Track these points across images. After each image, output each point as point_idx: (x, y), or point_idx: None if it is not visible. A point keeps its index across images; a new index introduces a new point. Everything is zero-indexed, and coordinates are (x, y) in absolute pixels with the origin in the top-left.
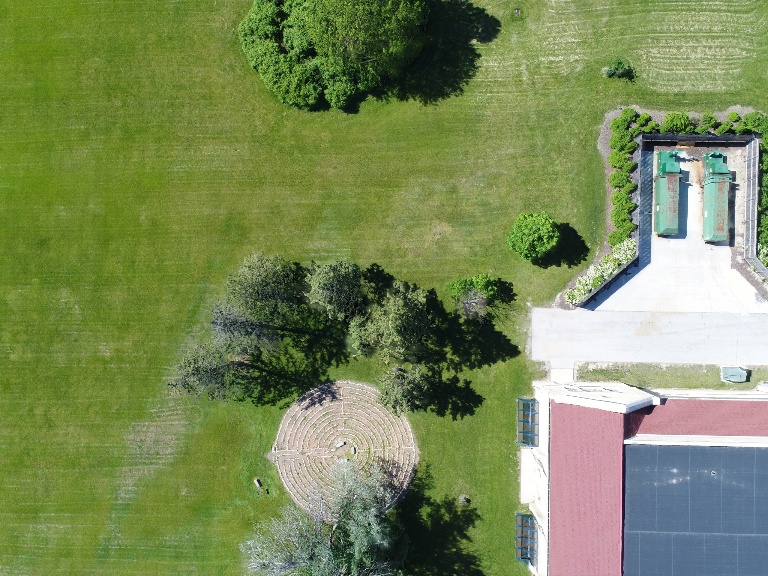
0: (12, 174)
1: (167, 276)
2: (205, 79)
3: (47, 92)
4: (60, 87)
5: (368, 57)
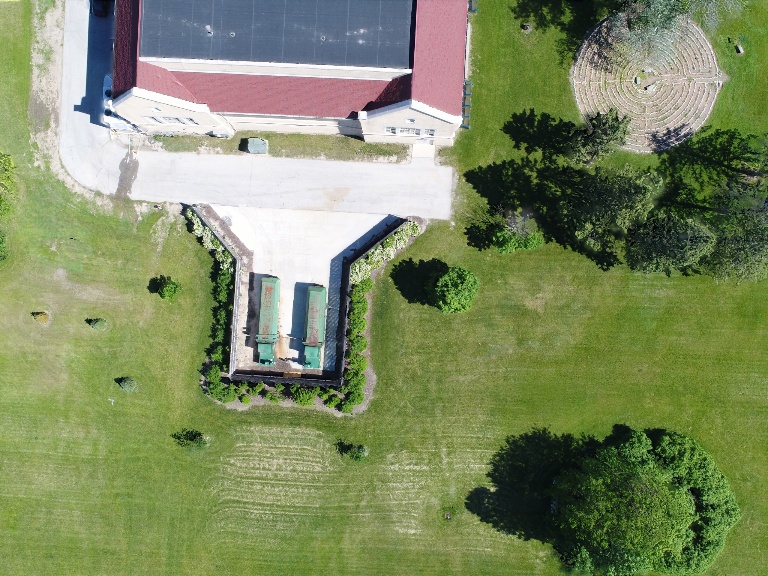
0: None
1: None
2: None
3: None
4: None
5: None
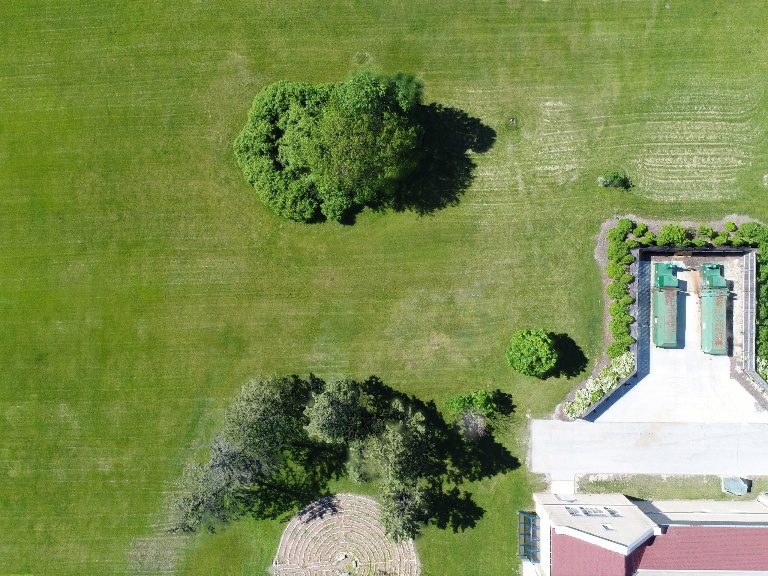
0: (9, 289)
1: (165, 390)
2: (201, 192)
3: (43, 207)
4: (56, 202)
5: (363, 180)
